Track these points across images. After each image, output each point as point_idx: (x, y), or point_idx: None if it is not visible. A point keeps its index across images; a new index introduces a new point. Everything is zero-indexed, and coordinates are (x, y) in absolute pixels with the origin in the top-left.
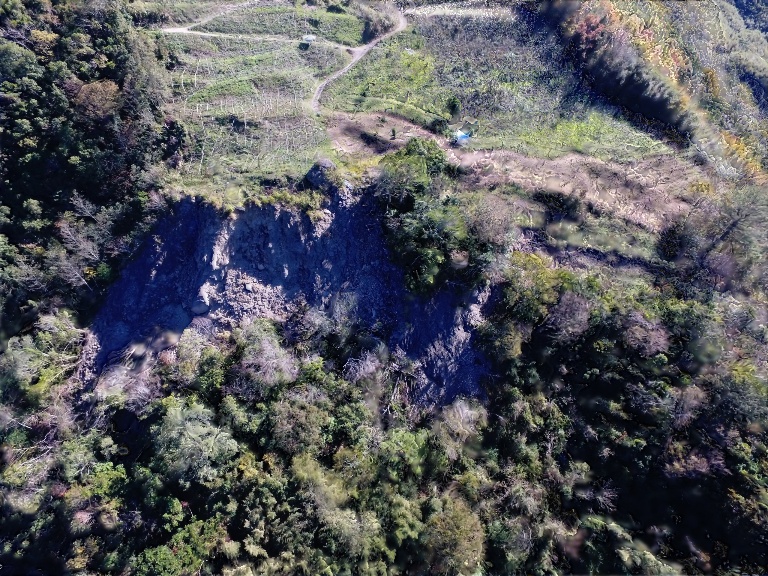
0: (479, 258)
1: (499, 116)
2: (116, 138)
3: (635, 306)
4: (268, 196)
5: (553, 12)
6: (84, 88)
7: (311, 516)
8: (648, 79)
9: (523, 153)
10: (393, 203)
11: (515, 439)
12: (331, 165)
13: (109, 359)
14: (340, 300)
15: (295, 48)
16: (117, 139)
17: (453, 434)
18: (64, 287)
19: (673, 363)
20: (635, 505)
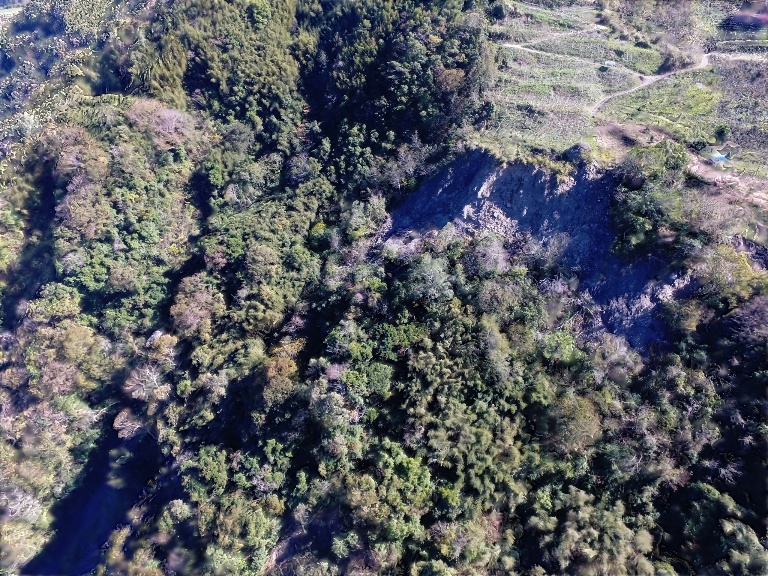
0: (686, 242)
1: (767, 149)
2: (450, 107)
3: None
4: (533, 159)
5: None
6: (446, 72)
7: (482, 350)
8: None
9: None
10: (626, 180)
11: (660, 393)
12: (588, 148)
13: (397, 231)
14: (556, 236)
15: (596, 69)
16: (450, 107)
17: (605, 353)
18: (388, 185)
19: None
20: (760, 497)
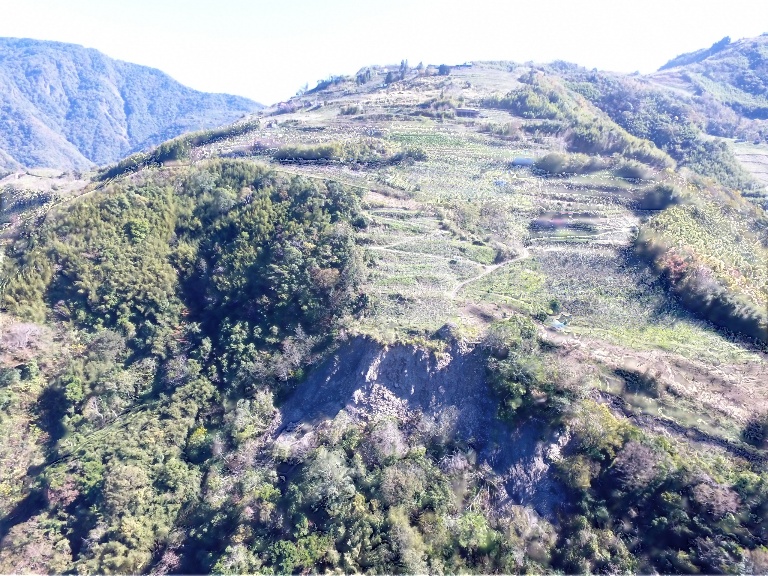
0: (557, 401)
1: (592, 315)
2: (329, 300)
3: (700, 465)
4: (411, 340)
5: (646, 253)
6: (322, 271)
7: (395, 552)
8: (733, 303)
9: (608, 341)
10: (493, 352)
11: (580, 564)
12: (456, 326)
13: (287, 426)
14: (446, 411)
15: (447, 263)
16: (329, 301)
17: (518, 529)
18: (275, 379)
19: (741, 523)
20: None
